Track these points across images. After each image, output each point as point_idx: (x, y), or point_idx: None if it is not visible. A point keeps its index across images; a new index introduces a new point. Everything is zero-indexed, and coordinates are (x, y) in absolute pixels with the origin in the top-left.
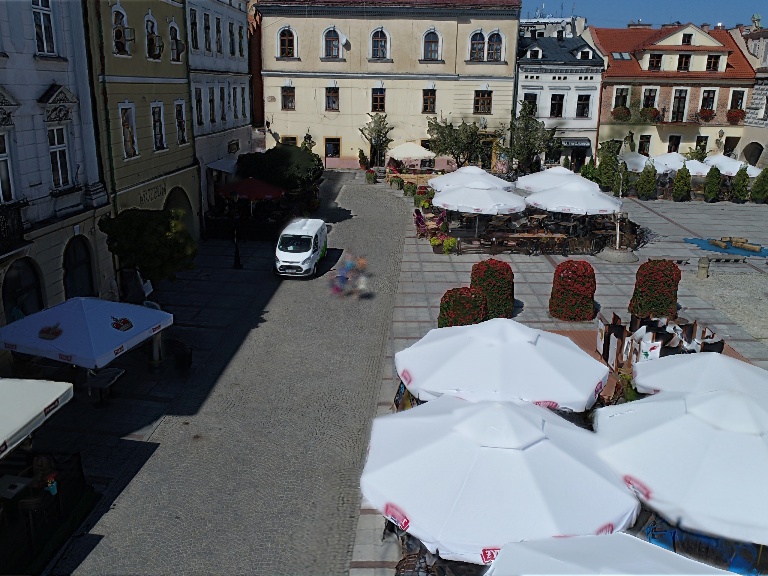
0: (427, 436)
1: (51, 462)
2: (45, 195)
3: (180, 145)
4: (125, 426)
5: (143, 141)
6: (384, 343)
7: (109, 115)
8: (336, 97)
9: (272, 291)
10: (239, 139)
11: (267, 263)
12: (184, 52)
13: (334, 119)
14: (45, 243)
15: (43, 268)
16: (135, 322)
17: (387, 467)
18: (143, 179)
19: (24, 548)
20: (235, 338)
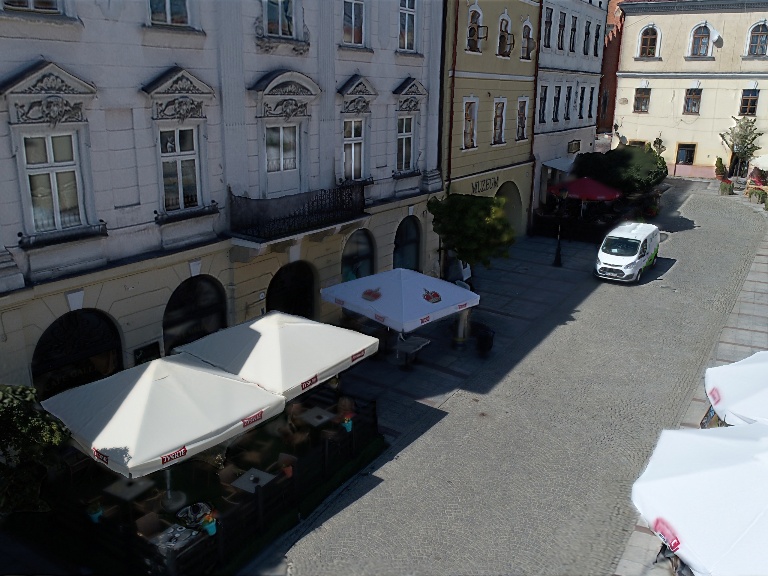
0: (721, 458)
1: (352, 405)
2: (388, 177)
3: (518, 141)
4: (422, 391)
5: (482, 134)
6: (703, 362)
7: (454, 108)
8: (697, 99)
9: (588, 292)
10: (581, 140)
11: (588, 264)
12: (535, 50)
13: (692, 123)
14: (382, 219)
15: (378, 241)
16: (444, 297)
17: (665, 480)
18: (477, 170)
19: (318, 470)
20: (540, 331)
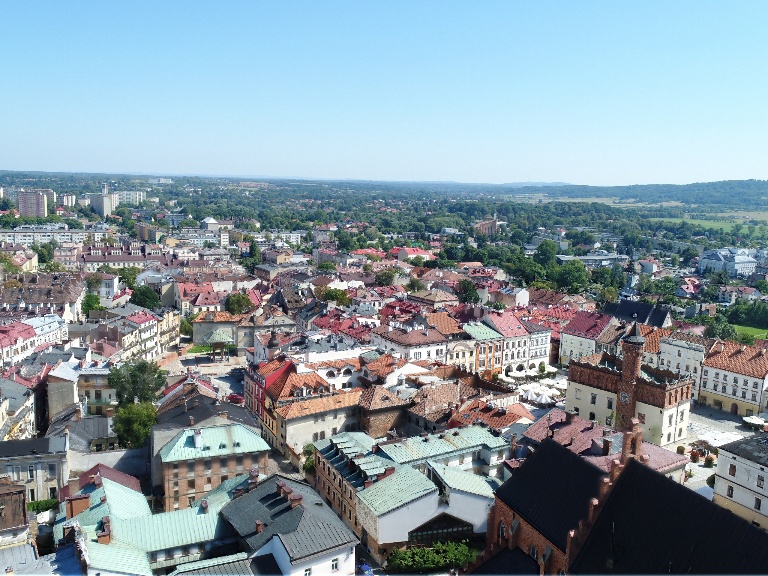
0: None
1: None
2: None
3: None
4: None
5: None
6: None
7: None
8: None
9: None
10: None
11: None
12: None
13: None
14: None
15: None
16: None
17: None
18: None
19: None
20: None
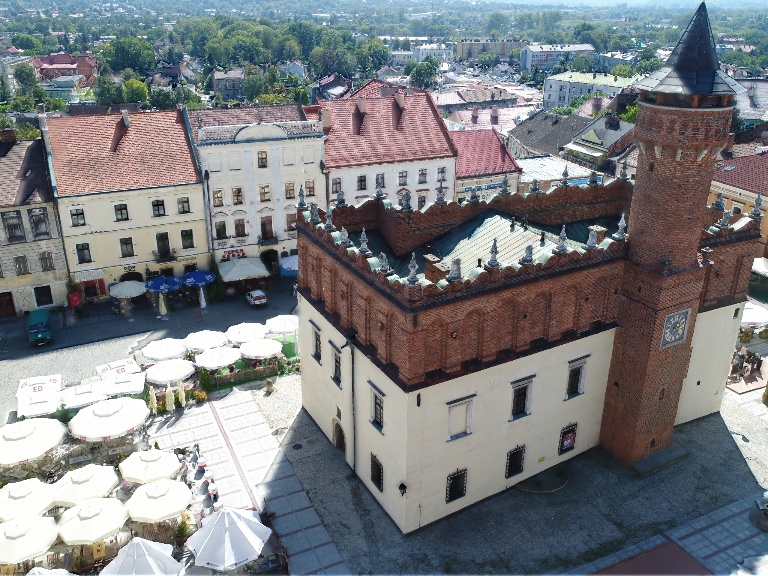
0: None
1: None
2: None
3: None
4: None
5: None
6: None
7: None
8: None
9: None
10: None
11: None
12: None
13: None
14: None
15: None
16: None
17: None
18: None
19: None
20: None
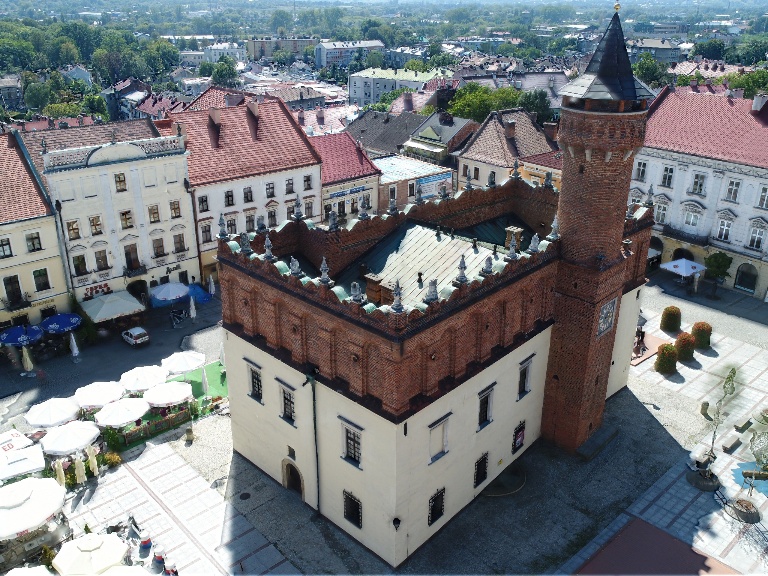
0: None
1: None
2: None
3: None
4: None
5: None
6: None
7: None
8: None
9: (767, 324)
10: None
11: None
12: None
13: None
14: None
15: None
16: None
17: None
18: None
19: None
20: None
